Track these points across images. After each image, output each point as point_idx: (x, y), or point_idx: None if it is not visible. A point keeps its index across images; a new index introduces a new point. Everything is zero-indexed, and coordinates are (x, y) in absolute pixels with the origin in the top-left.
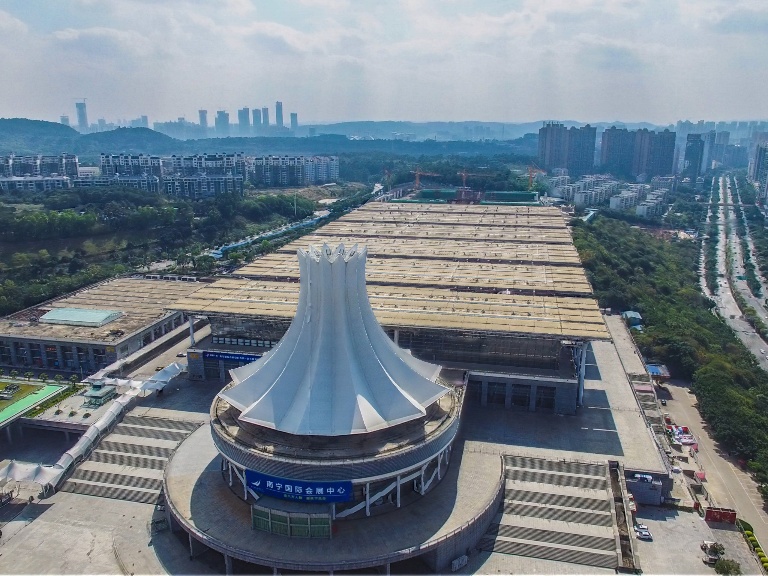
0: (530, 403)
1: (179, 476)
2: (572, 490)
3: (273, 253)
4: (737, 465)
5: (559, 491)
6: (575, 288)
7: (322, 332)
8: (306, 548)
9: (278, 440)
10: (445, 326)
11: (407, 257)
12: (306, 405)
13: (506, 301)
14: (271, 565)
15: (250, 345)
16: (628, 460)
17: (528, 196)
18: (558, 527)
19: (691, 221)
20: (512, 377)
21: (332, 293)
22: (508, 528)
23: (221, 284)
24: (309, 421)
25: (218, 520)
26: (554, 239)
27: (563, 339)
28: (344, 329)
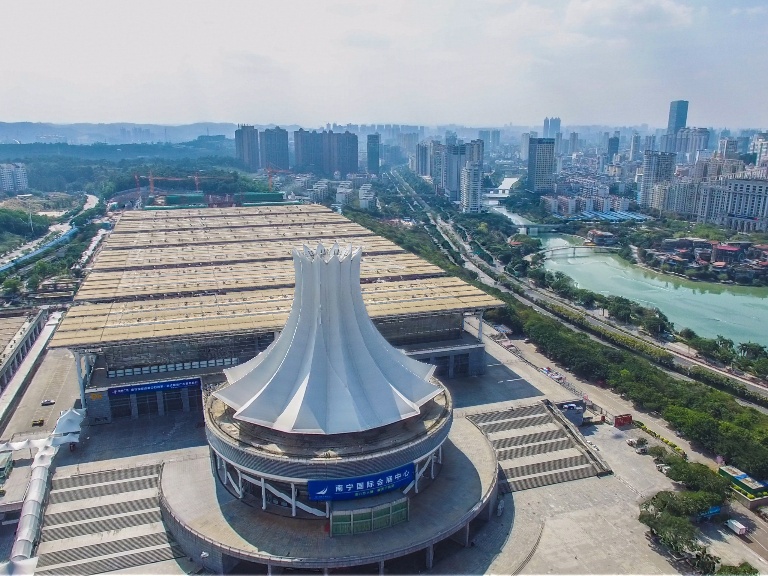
0: (449, 371)
1: (198, 518)
2: (532, 429)
3: (93, 273)
4: (598, 386)
5: (524, 432)
6: (430, 270)
7: (339, 331)
8: (396, 535)
9: (330, 444)
10: (374, 315)
11: (246, 261)
12: (352, 403)
13: (393, 288)
14: (379, 560)
15: (158, 372)
16: (551, 397)
17: (276, 196)
18: (543, 459)
19: (405, 211)
20: (434, 351)
21: (340, 292)
22: (511, 471)
23: (81, 312)
24: (362, 417)
25: (289, 542)
26: (357, 232)
27: (466, 311)
28: (357, 325)
